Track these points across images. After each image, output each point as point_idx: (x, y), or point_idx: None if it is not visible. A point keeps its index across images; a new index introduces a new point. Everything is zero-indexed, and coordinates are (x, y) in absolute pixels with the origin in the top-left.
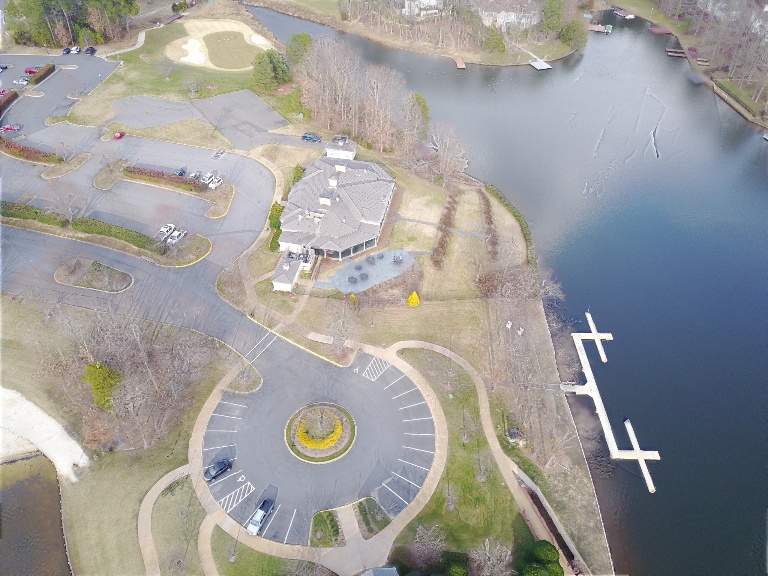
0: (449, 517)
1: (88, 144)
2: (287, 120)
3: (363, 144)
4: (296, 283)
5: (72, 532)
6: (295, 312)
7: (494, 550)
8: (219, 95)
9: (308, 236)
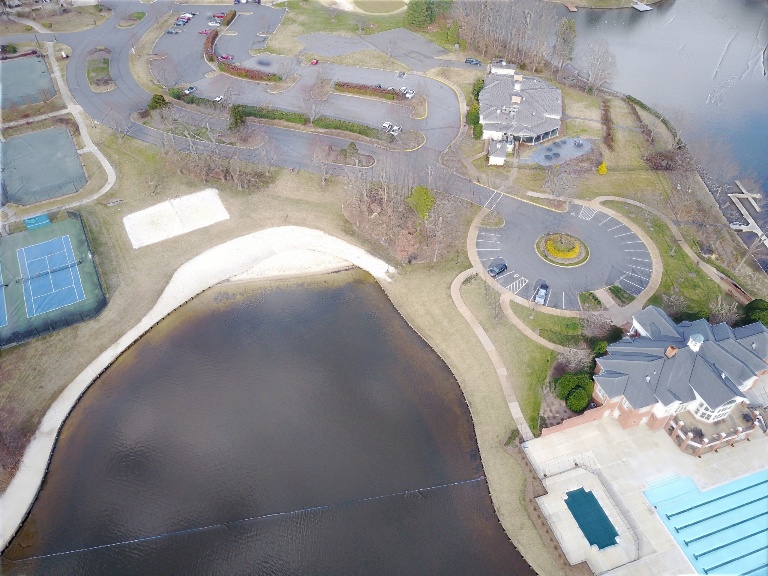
0: (677, 295)
1: (293, 68)
2: (446, 49)
3: (516, 66)
4: (504, 160)
5: (403, 309)
6: (511, 179)
7: (721, 307)
8: (381, 32)
9: (506, 126)
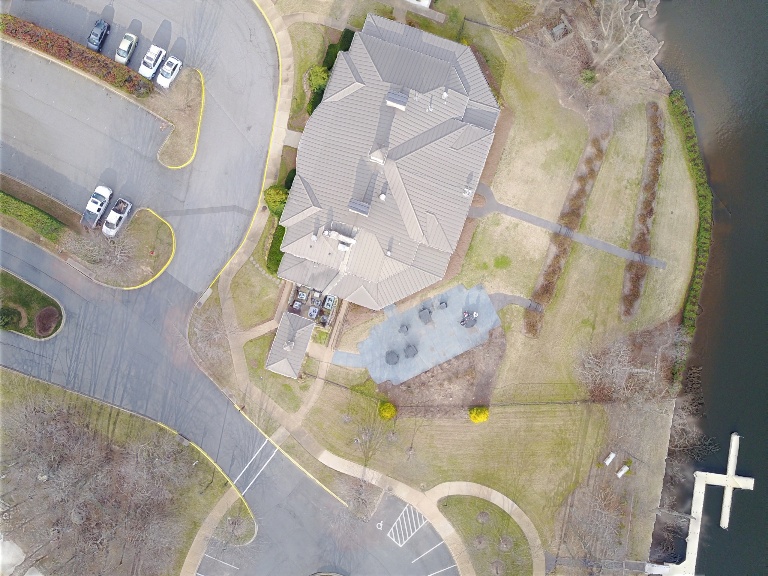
0: None
1: None
2: None
3: None
4: (306, 353)
5: None
6: (303, 409)
7: None
8: None
9: (327, 271)
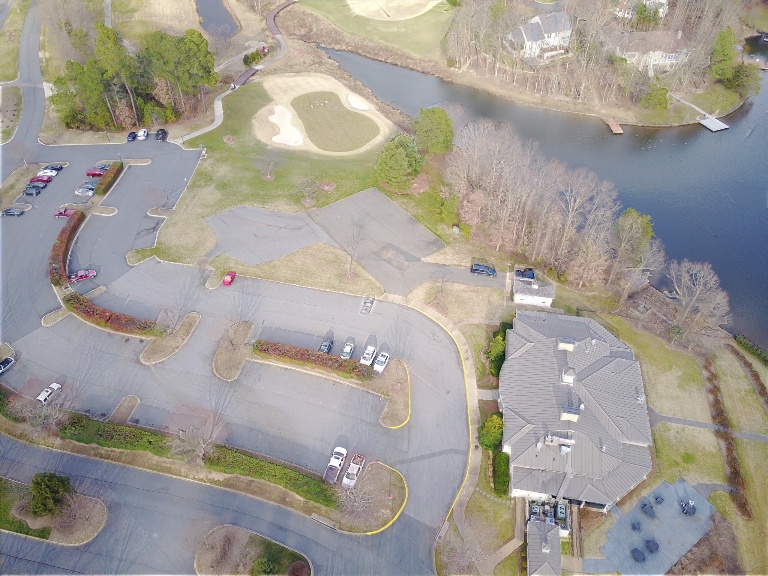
0: None
1: (191, 296)
2: (440, 238)
3: (551, 274)
4: None
5: None
6: None
7: None
8: (340, 200)
9: (555, 476)
